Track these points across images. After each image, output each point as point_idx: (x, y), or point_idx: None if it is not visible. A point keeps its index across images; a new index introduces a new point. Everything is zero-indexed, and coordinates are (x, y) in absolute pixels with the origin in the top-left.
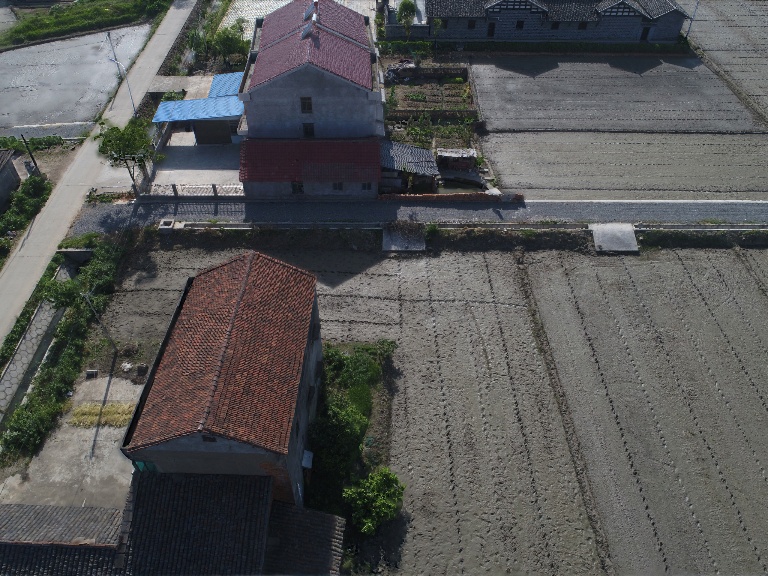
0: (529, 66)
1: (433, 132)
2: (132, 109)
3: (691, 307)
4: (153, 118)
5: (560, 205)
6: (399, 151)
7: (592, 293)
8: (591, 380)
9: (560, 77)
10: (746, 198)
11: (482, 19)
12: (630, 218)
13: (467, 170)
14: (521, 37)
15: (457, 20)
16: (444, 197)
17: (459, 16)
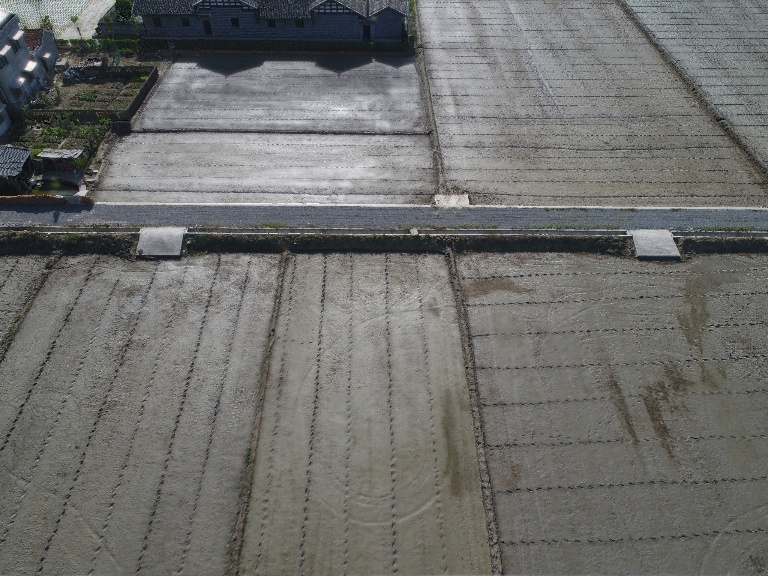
0: (231, 65)
1: (71, 132)
2: None
3: (187, 314)
4: None
5: (128, 208)
6: None
7: (97, 299)
8: (18, 390)
9: (254, 76)
10: (341, 201)
11: (194, 16)
12: (189, 222)
13: (72, 171)
14: (240, 35)
15: (168, 17)
16: (8, 199)
17: (166, 13)
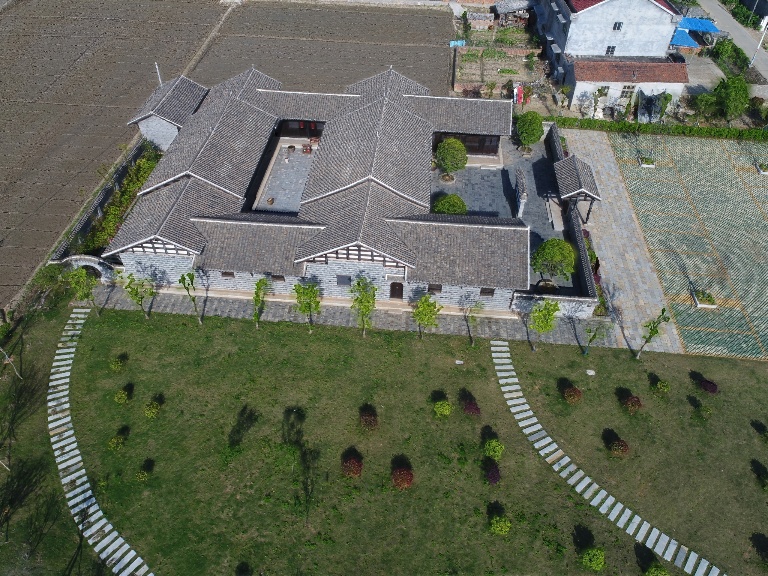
0: None
1: None
2: (761, 69)
3: None
4: (711, 22)
5: None
6: (522, 5)
7: None
8: None
9: None
10: (298, 6)
11: None
12: None
13: None
14: None
15: None
16: (491, 0)
17: None
